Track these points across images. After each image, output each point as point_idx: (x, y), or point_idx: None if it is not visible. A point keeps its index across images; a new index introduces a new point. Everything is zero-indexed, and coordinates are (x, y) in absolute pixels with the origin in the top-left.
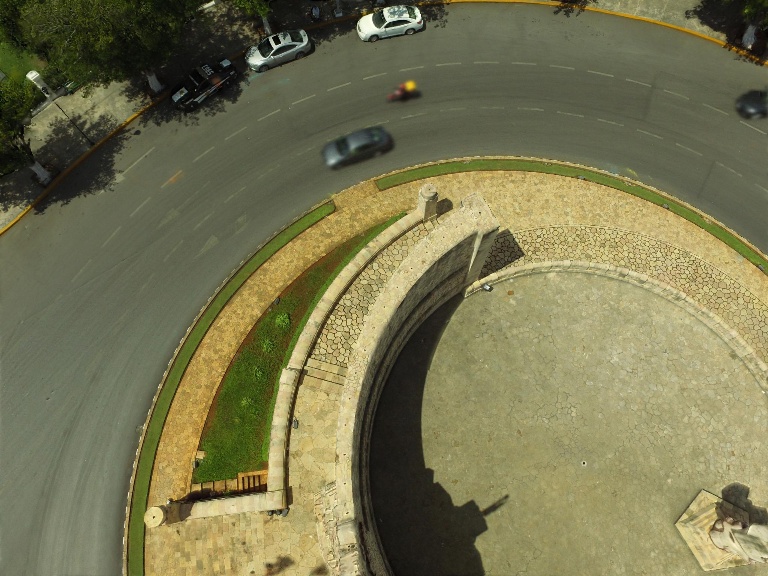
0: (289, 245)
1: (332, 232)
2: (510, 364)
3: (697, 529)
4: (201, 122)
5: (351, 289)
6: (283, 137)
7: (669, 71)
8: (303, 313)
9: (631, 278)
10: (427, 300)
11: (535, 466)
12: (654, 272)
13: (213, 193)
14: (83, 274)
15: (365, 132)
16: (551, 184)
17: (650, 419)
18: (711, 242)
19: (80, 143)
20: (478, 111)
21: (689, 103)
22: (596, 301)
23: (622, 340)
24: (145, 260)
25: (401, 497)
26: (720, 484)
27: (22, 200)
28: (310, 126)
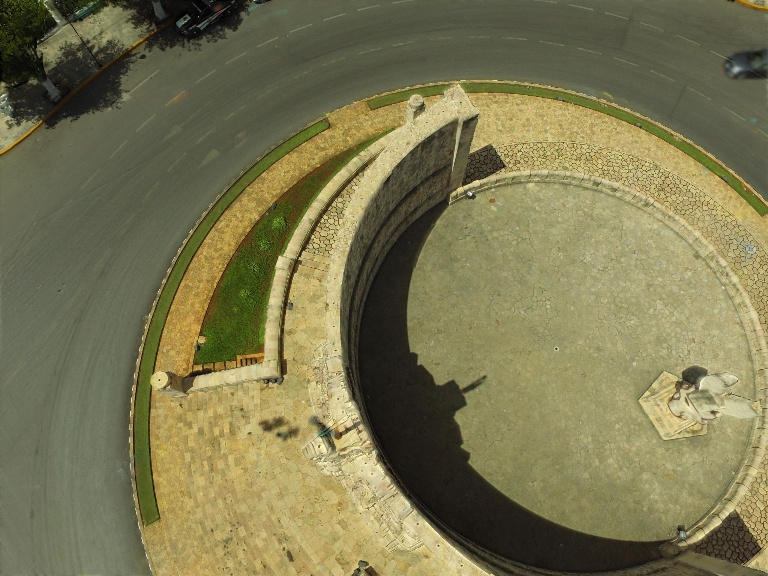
0: (286, 157)
1: (326, 146)
2: (490, 263)
3: (657, 401)
4: (203, 48)
5: (343, 193)
6: (281, 62)
7: (646, 6)
8: (298, 217)
9: (604, 187)
10: (413, 195)
11: (511, 351)
12: (626, 182)
13: (214, 111)
14: (92, 182)
15: (358, 58)
16: (532, 105)
17: (618, 311)
18: (680, 157)
19: (89, 65)
20: (465, 40)
21: (664, 34)
22: (571, 208)
23: (594, 242)
24: (150, 170)
25: (387, 377)
26: (681, 367)
27: (34, 115)
28: (306, 52)
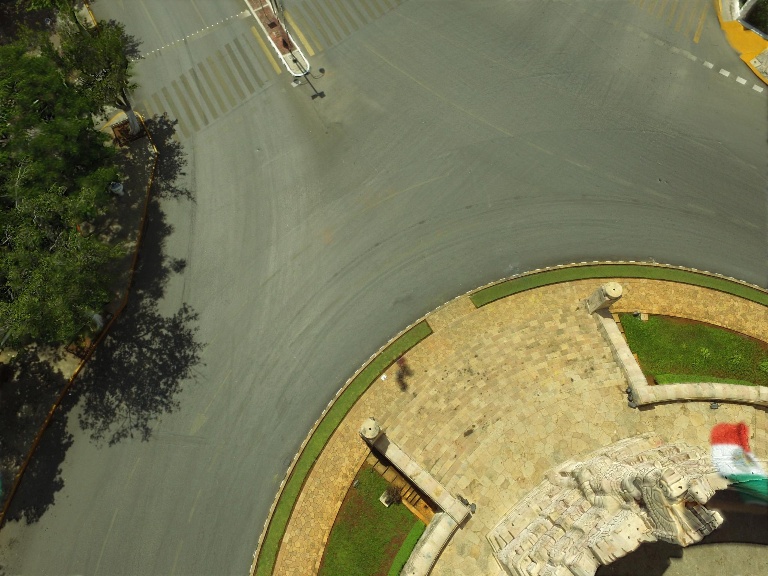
0: None
1: None
2: None
3: None
4: None
5: None
6: None
7: None
8: None
9: None
10: None
11: None
12: None
13: None
14: None
15: None
16: None
17: None
18: None
19: None
20: None
21: None
22: None
23: None
24: None
25: None
26: None
27: None
28: None
